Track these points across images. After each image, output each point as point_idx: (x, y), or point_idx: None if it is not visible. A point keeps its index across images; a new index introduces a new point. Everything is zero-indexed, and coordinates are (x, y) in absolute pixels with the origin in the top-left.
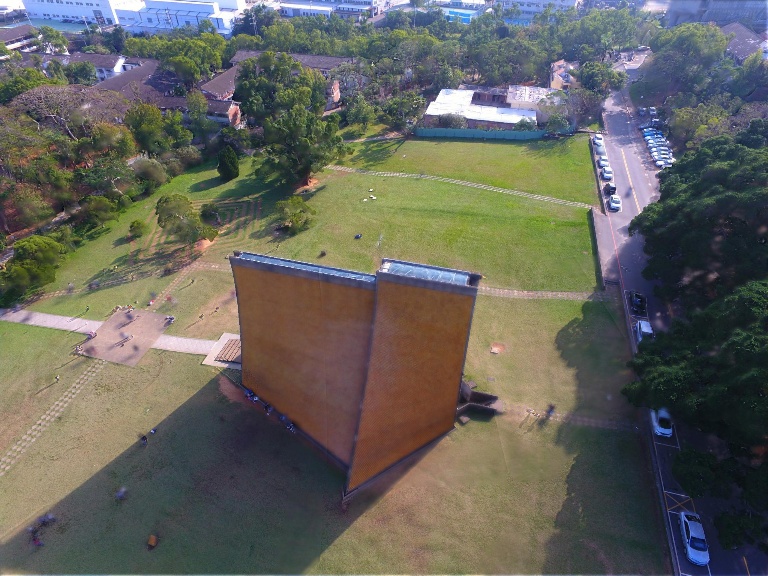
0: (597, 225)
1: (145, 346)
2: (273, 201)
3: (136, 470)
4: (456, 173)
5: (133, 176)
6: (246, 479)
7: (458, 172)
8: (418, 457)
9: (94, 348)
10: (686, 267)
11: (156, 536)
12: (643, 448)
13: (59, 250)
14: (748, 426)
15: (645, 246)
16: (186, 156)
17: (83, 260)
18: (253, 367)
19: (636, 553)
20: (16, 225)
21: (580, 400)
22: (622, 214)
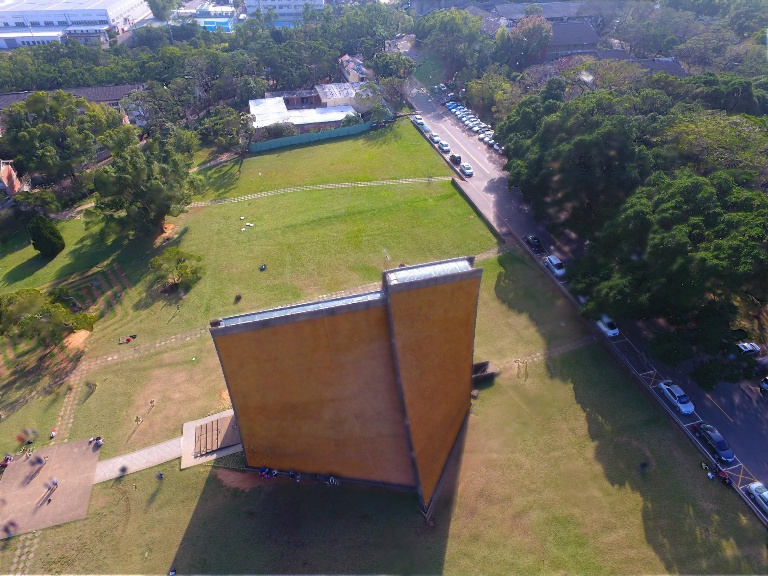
0: (466, 191)
1: (84, 486)
2: (134, 262)
3: None
4: (317, 179)
5: None
6: (321, 556)
7: (318, 177)
8: (460, 444)
9: (6, 524)
10: (563, 203)
11: None
12: (608, 351)
13: None
14: (691, 299)
15: (523, 196)
16: None
17: None
18: (260, 441)
19: (652, 428)
20: None
21: (545, 335)
22: (477, 177)
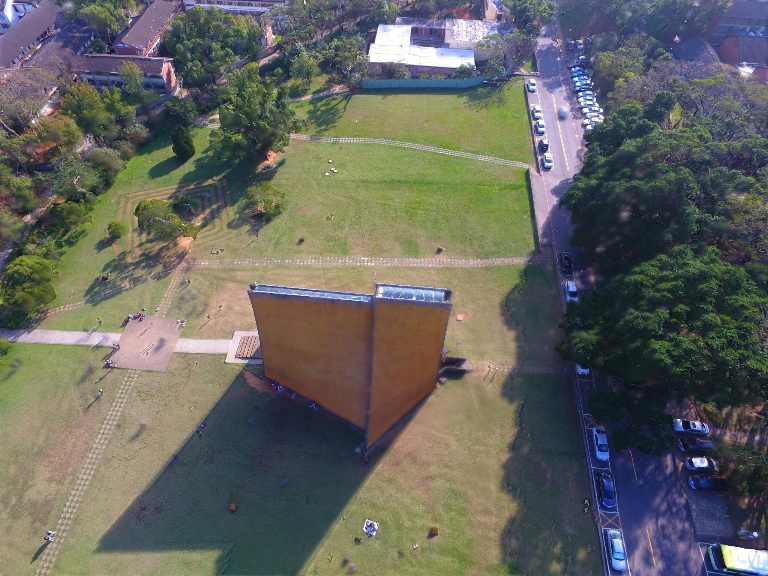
0: (534, 187)
1: (168, 351)
2: (239, 182)
3: (200, 458)
4: (406, 134)
5: None
6: (289, 451)
7: (408, 133)
8: (413, 414)
9: (123, 359)
10: (602, 237)
11: (234, 503)
12: (570, 385)
13: (51, 267)
14: (634, 378)
15: (572, 216)
16: (135, 136)
17: (73, 270)
18: (274, 364)
19: (565, 459)
20: None
21: (526, 353)
22: (554, 173)
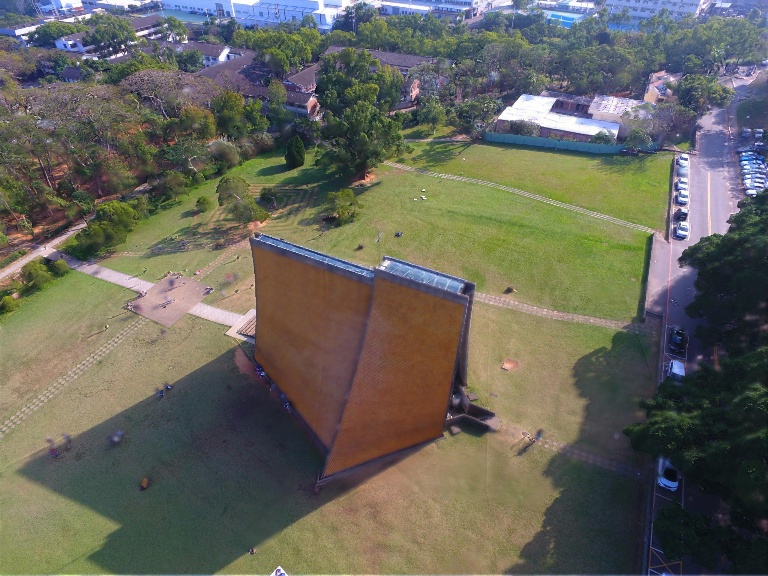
0: (655, 252)
1: (183, 310)
2: None
3: (148, 418)
4: (515, 181)
5: (209, 156)
6: (236, 445)
7: (517, 181)
8: (399, 458)
9: (141, 306)
10: (737, 309)
11: (149, 480)
12: (640, 497)
13: (133, 216)
14: (744, 493)
15: (696, 280)
16: (260, 142)
17: (153, 227)
18: (264, 344)
19: None
20: (109, 190)
21: (583, 433)
22: (688, 243)
